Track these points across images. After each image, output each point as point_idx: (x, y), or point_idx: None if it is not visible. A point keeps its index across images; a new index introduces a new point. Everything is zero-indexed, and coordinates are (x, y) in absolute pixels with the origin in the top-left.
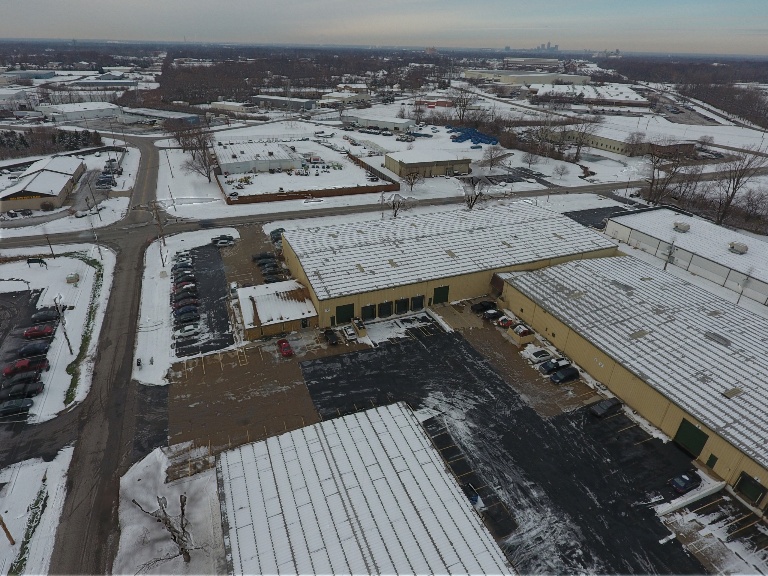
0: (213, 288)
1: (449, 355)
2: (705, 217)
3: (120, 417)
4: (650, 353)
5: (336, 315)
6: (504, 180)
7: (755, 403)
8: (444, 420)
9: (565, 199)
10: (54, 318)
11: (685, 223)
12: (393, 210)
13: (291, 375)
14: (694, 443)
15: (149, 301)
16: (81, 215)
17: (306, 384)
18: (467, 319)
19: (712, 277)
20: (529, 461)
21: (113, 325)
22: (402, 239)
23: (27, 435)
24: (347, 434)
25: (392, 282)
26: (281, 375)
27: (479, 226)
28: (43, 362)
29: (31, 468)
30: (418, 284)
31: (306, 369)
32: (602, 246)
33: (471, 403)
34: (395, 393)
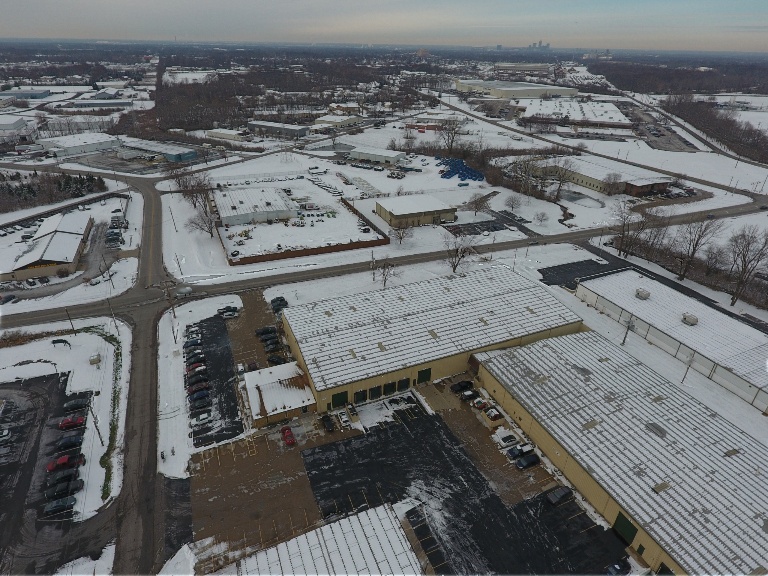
0: (222, 368)
1: (430, 440)
2: (665, 281)
3: (151, 513)
4: (598, 445)
5: (332, 401)
6: (487, 229)
7: (678, 498)
8: (424, 510)
9: (543, 251)
10: (83, 406)
11: (646, 291)
12: (383, 274)
13: (294, 465)
14: (628, 532)
15: (166, 384)
16: (95, 283)
17: (307, 475)
18: (447, 400)
19: (666, 348)
20: (492, 551)
21: (136, 412)
22: (390, 318)
23: (75, 534)
24: (342, 539)
25: (381, 369)
26: (286, 465)
27: (460, 300)
28: (80, 457)
29: (82, 567)
30: (404, 370)
31: (307, 458)
32: (568, 321)
33: (447, 492)
34: (383, 483)
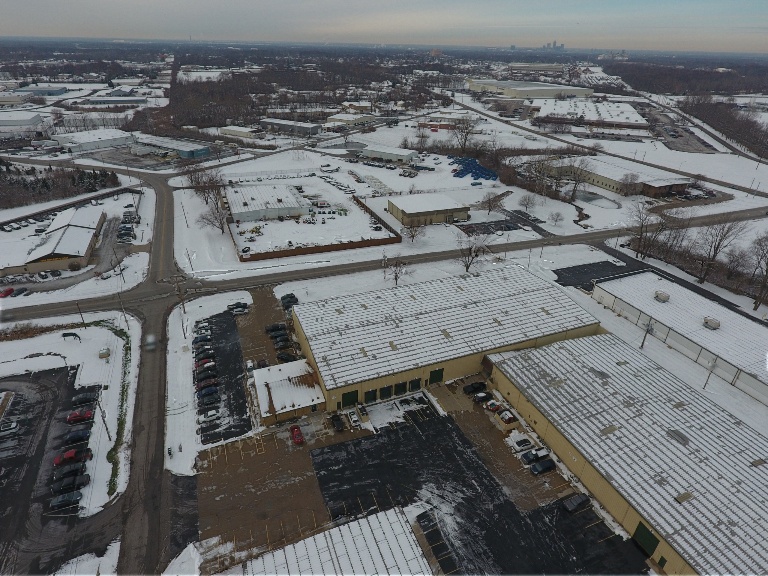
0: (231, 365)
1: (442, 443)
2: (685, 283)
3: (157, 510)
4: (617, 452)
5: (342, 400)
6: (501, 228)
7: (702, 509)
8: (435, 515)
9: (558, 251)
10: (92, 400)
11: (665, 293)
12: (395, 273)
13: (303, 465)
14: (649, 543)
15: (174, 379)
16: (106, 277)
17: (316, 475)
18: (459, 401)
19: (686, 352)
20: (506, 559)
21: (144, 408)
22: (402, 317)
23: (80, 529)
24: (352, 542)
25: (392, 368)
26: (294, 465)
27: (473, 300)
28: (87, 452)
29: (86, 564)
30: (415, 370)
31: (316, 458)
32: (585, 323)
33: (459, 496)
34: (393, 485)
